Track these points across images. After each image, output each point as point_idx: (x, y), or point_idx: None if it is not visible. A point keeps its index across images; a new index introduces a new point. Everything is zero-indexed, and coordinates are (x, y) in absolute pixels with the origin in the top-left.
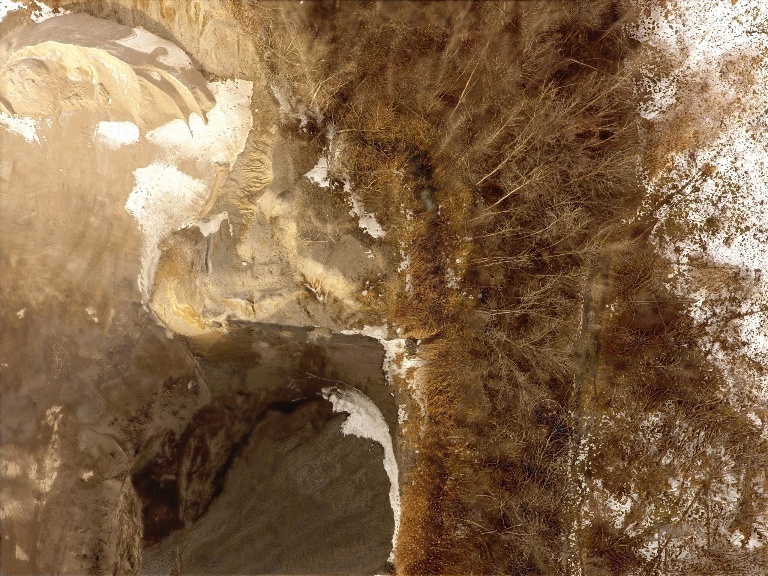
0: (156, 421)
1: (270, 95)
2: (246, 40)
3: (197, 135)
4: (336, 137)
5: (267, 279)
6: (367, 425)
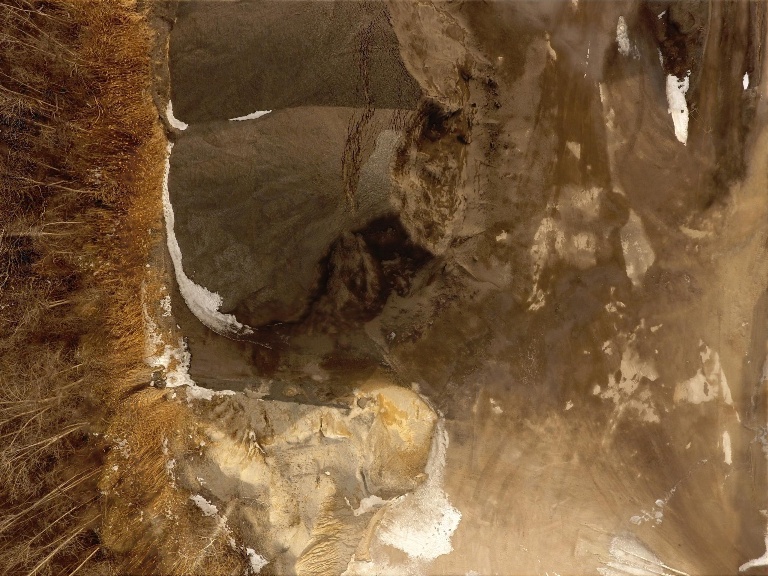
0: (425, 300)
1: None
2: None
3: None
4: None
5: (303, 459)
6: (200, 298)
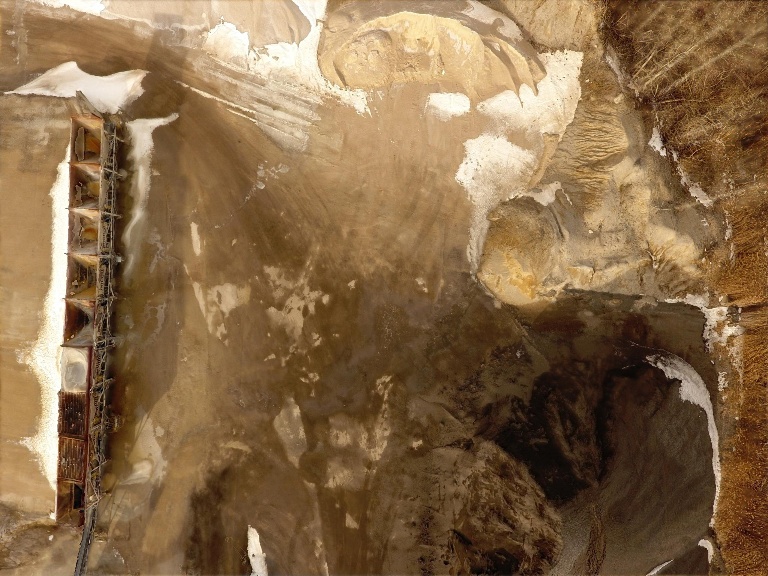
0: (491, 389)
1: (607, 65)
2: (588, 10)
3: (527, 106)
4: (660, 107)
5: (613, 247)
6: (695, 392)
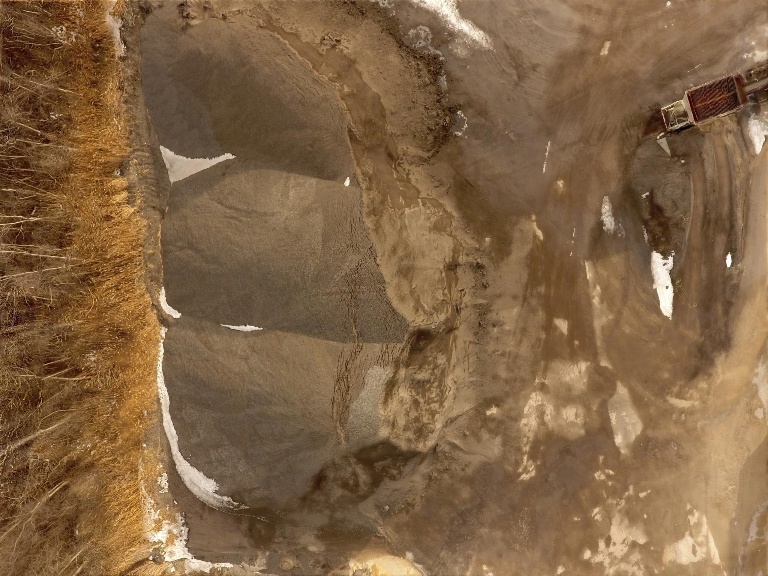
0: (418, 477)
1: None
2: None
3: None
4: None
5: None
6: (196, 479)
